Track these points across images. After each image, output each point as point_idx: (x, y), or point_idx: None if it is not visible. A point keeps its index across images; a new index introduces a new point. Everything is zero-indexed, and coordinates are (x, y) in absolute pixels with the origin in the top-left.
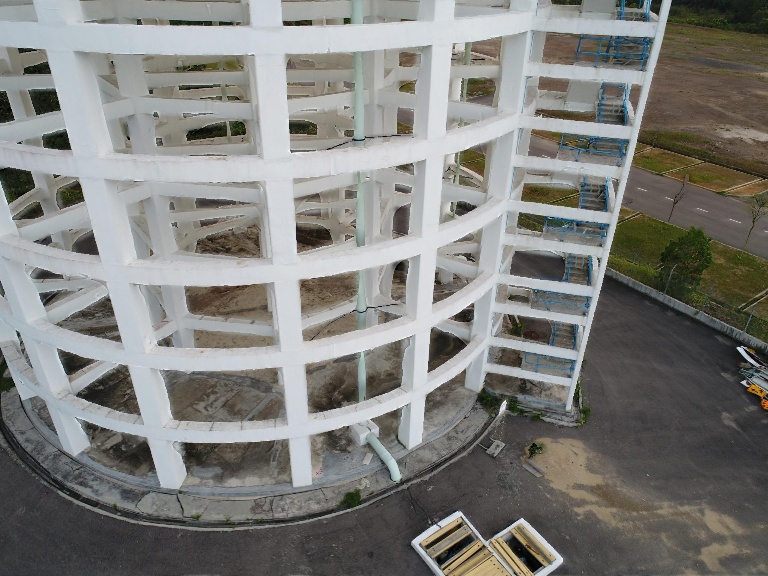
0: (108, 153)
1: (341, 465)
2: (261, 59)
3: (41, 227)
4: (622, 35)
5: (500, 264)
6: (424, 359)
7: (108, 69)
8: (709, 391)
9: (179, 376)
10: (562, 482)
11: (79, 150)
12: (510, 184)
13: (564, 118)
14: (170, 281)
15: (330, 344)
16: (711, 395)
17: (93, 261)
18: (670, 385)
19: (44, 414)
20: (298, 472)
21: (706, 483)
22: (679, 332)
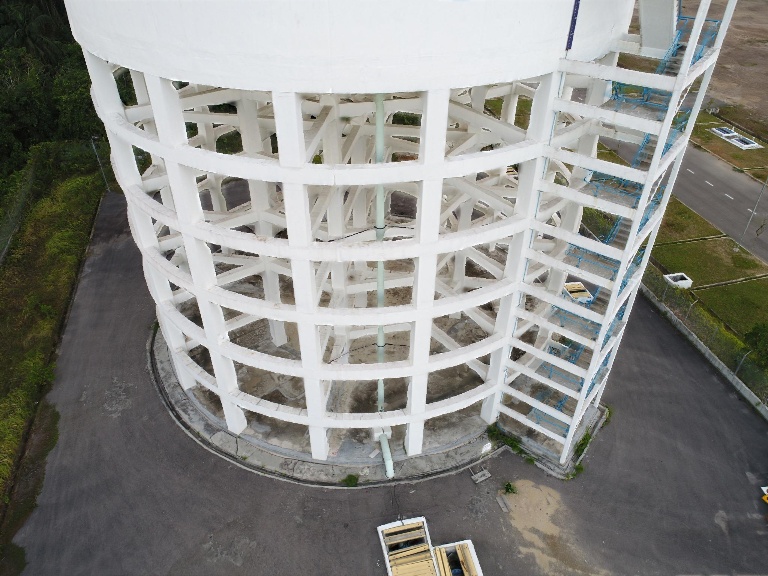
0: (199, 221)
1: (353, 452)
2: (287, 186)
3: (175, 241)
4: (617, 176)
5: (513, 330)
6: (422, 394)
7: None
8: (720, 486)
9: (270, 347)
10: (522, 522)
11: (181, 218)
12: (523, 270)
13: (761, 135)
14: (231, 306)
15: (339, 370)
16: (719, 490)
17: (190, 282)
18: (682, 468)
19: None
20: (316, 449)
21: (655, 567)
22: (729, 418)
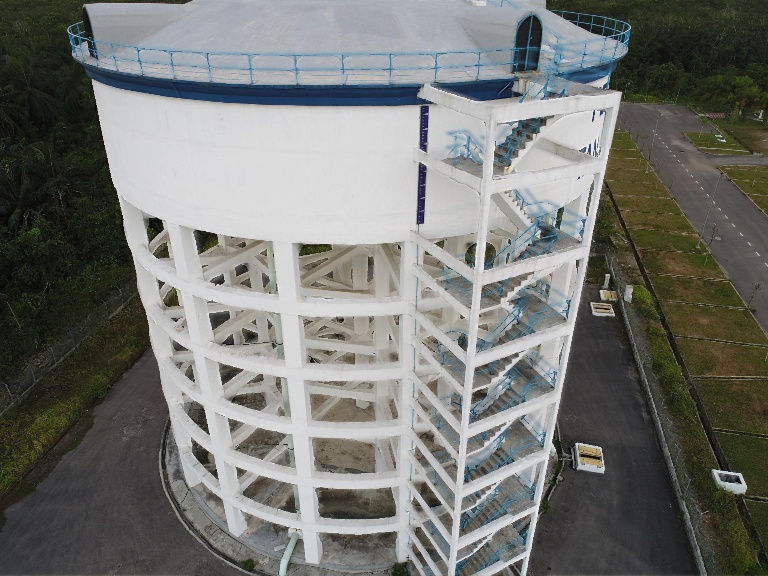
0: (154, 303)
1: (263, 539)
2: (183, 293)
3: (178, 312)
4: (451, 351)
5: (410, 472)
6: (309, 506)
7: None
8: None
9: None
10: None
11: None
12: (410, 416)
13: None
14: None
15: (237, 458)
16: None
17: None
18: None
19: (195, 402)
20: (230, 523)
21: None
22: None
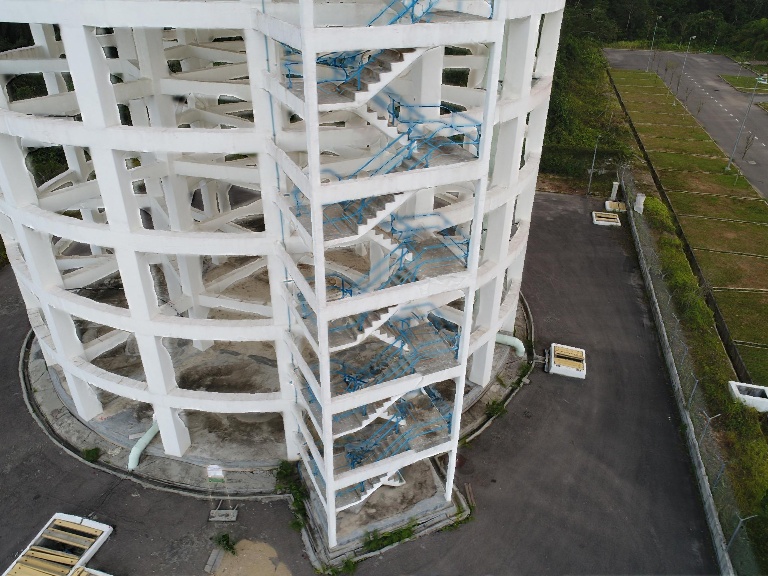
0: None
1: (119, 425)
2: None
3: None
4: (289, 44)
5: (288, 319)
6: (155, 366)
7: (185, 40)
8: None
9: None
10: None
11: None
12: (278, 223)
13: None
14: None
15: (60, 297)
16: None
17: None
18: None
19: None
20: (77, 403)
21: None
22: None
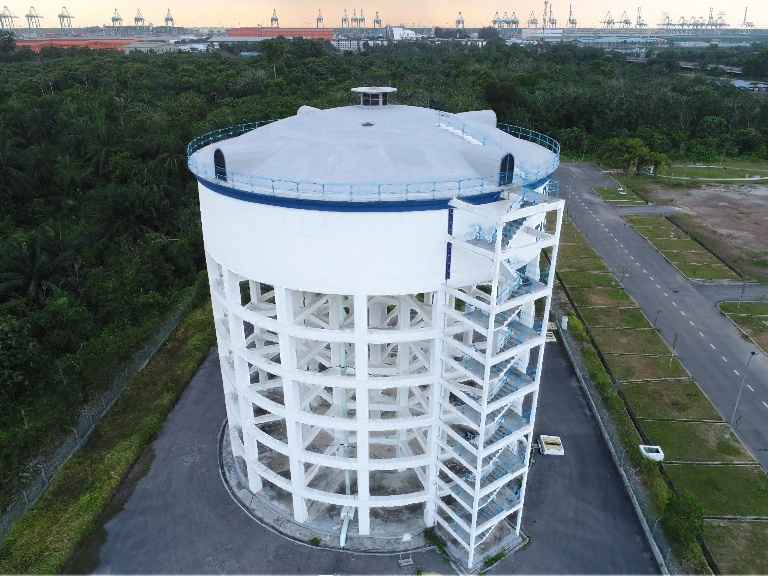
0: (242, 346)
1: (323, 523)
2: (280, 335)
3: None
4: (473, 358)
5: (437, 453)
6: (365, 486)
7: None
8: None
9: None
10: None
11: (233, 343)
12: (438, 410)
13: None
14: (253, 401)
15: (310, 456)
16: None
17: (235, 381)
18: None
19: None
20: (297, 513)
21: None
22: (632, 571)
